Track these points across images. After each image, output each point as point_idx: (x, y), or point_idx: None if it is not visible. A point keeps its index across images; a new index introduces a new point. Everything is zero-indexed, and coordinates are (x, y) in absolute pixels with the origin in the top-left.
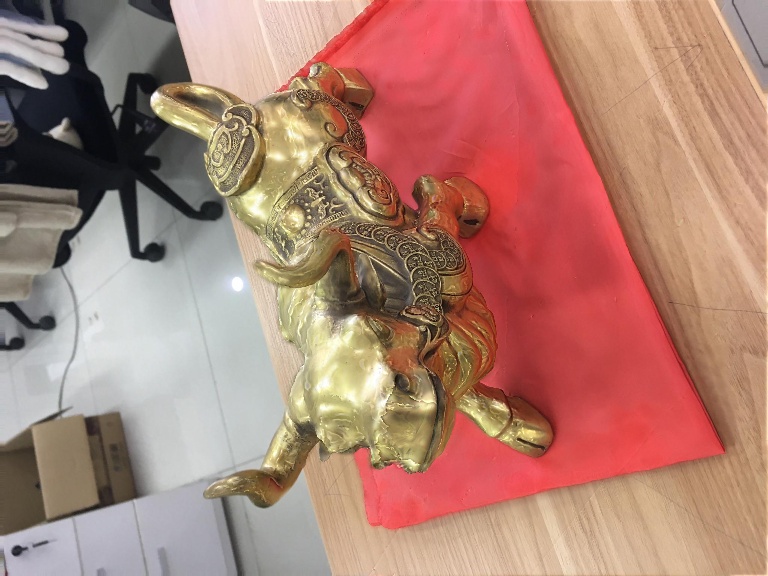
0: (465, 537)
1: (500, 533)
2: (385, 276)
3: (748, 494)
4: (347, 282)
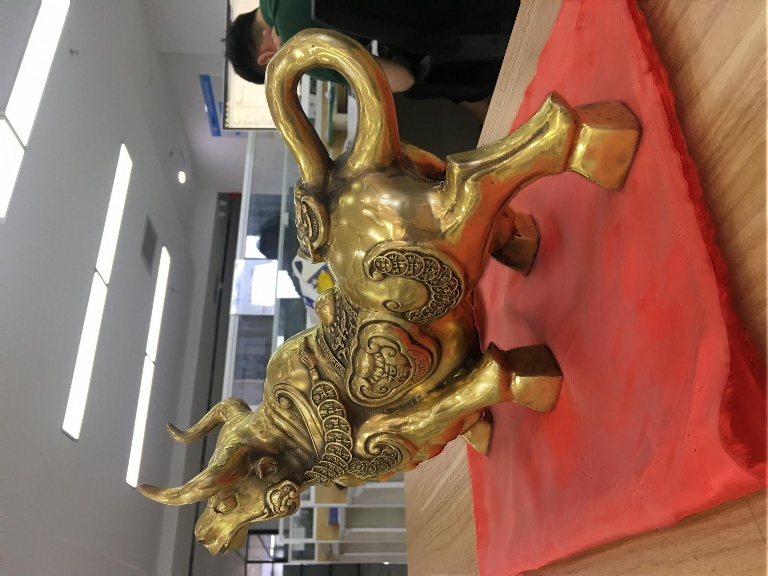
0: None
1: None
2: None
3: None
4: None
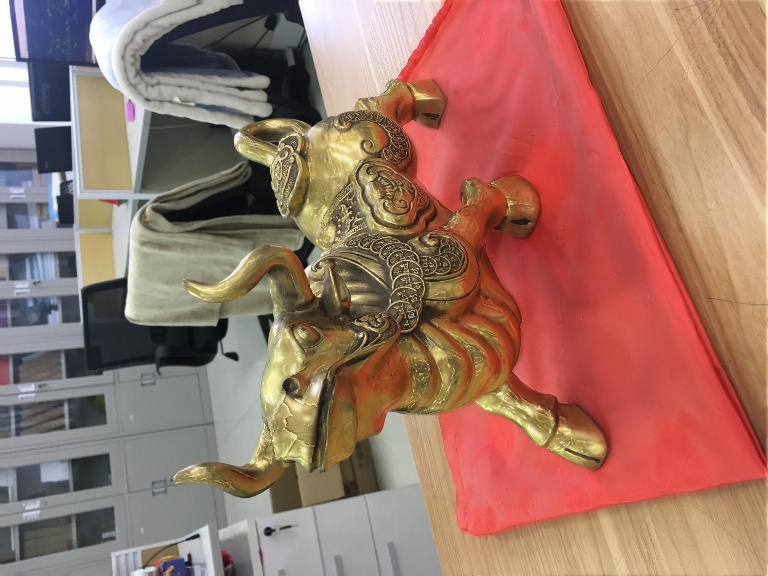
0: (541, 551)
1: (569, 549)
2: (373, 285)
3: None
4: (293, 294)
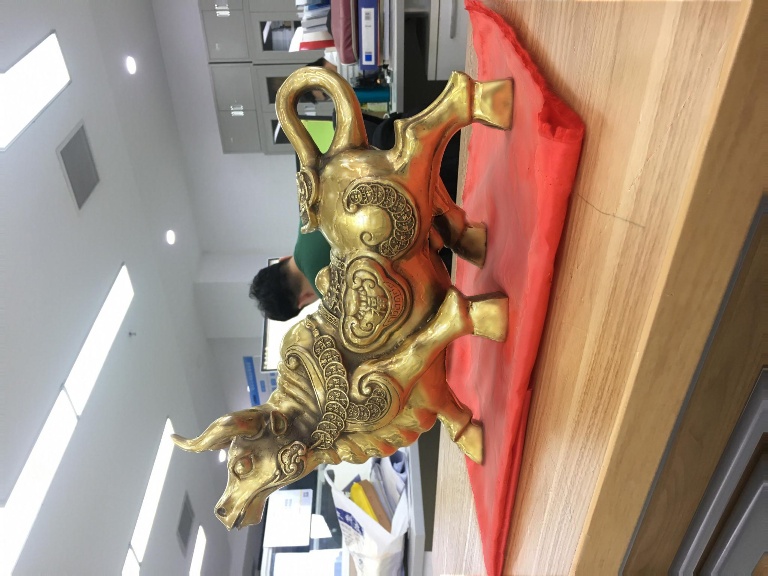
0: None
1: None
2: (316, 399)
3: None
4: None
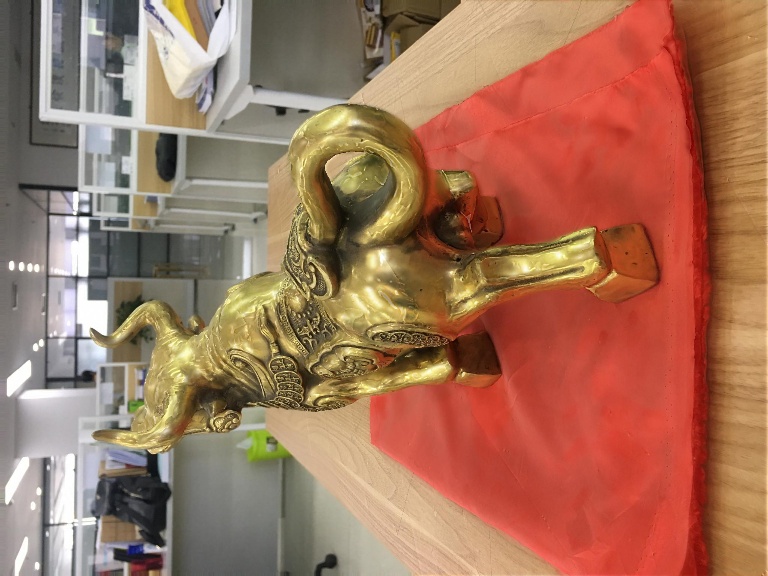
0: None
1: None
2: None
3: (368, 438)
4: None
